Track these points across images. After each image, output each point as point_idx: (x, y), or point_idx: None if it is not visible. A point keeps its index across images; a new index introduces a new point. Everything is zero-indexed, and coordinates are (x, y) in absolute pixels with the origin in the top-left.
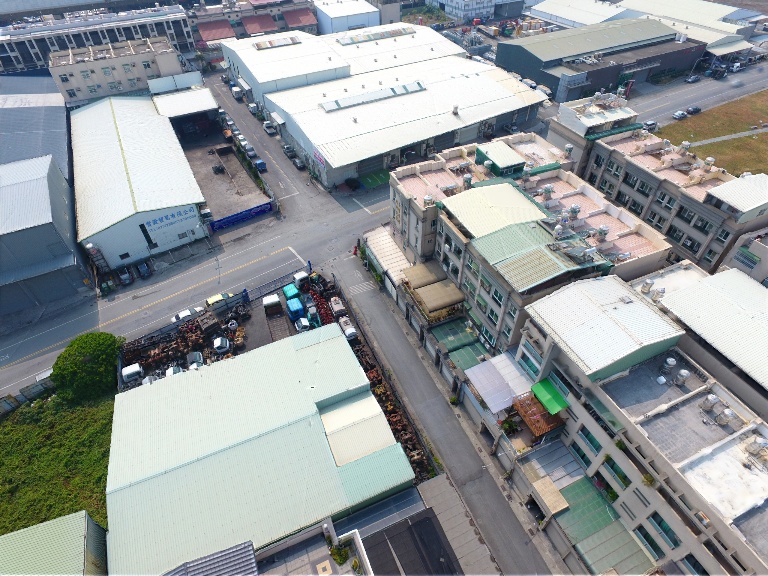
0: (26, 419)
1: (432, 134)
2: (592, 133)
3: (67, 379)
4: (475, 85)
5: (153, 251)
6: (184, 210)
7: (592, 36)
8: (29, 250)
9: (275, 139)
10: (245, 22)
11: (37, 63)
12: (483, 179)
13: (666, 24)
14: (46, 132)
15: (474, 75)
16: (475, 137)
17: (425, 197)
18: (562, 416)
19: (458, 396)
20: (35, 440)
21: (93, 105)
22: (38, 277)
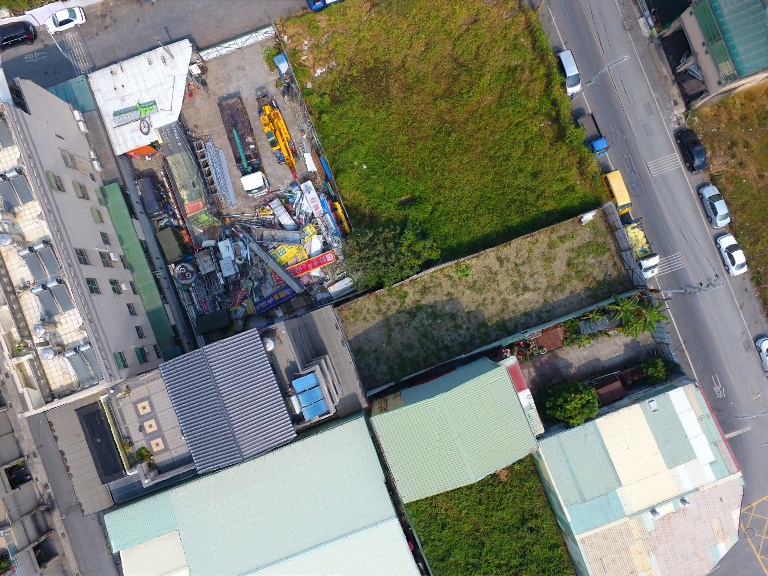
0: None
1: None
2: None
3: None
4: None
5: None
6: None
7: None
8: None
9: None
10: None
11: None
12: None
13: None
14: None
15: None
16: None
17: None
18: None
19: None
20: (528, 575)
21: None
22: None
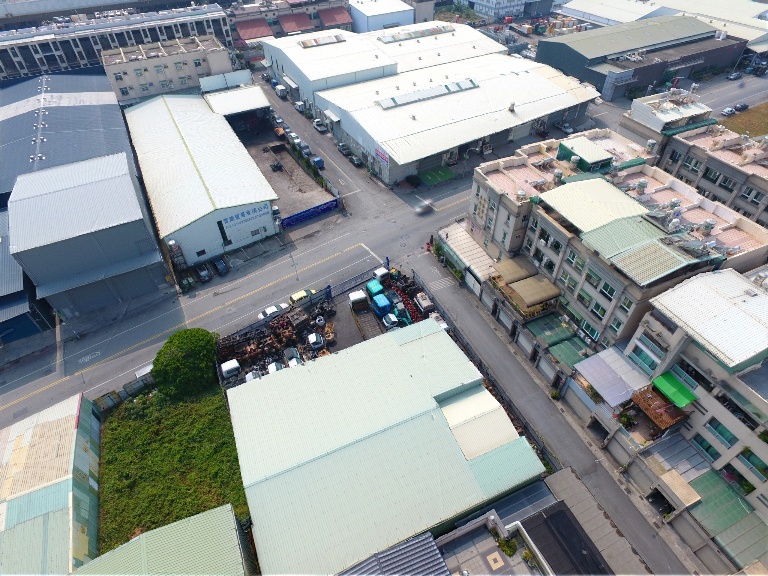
0: (131, 415)
1: (492, 131)
2: (668, 129)
3: (170, 375)
4: (526, 82)
5: (227, 248)
6: (259, 207)
7: (633, 33)
8: (118, 247)
9: (327, 137)
10: (282, 21)
11: (80, 62)
12: (569, 174)
13: (704, 21)
14: (106, 130)
15: (524, 72)
16: (527, 134)
17: (519, 192)
18: (686, 409)
19: (560, 391)
20: (145, 435)
21: (147, 103)
22: (127, 274)
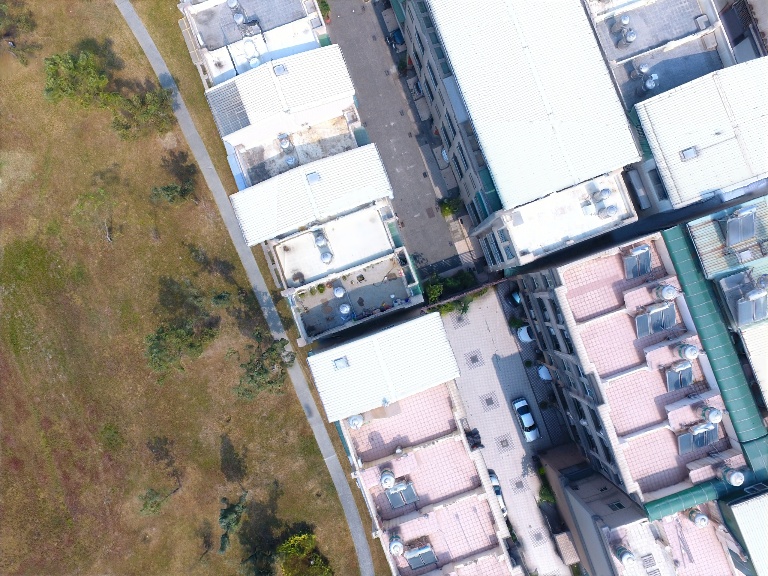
0: None
1: None
2: None
3: None
4: None
5: None
6: None
7: None
8: None
9: None
10: None
11: None
12: None
13: None
14: None
15: None
16: None
17: None
18: None
19: None
20: None
21: None
22: None
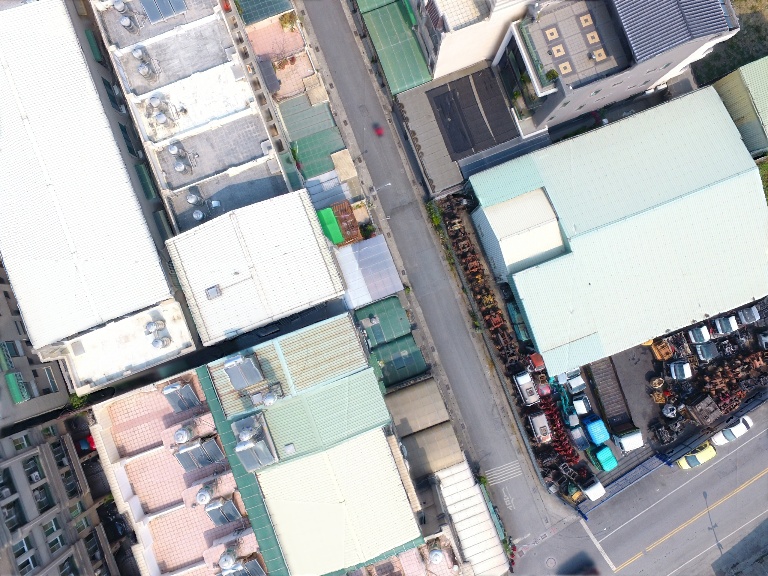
0: None
1: None
2: None
3: None
4: None
5: None
6: None
7: None
8: None
9: None
10: None
11: None
12: None
13: None
14: None
15: None
16: None
17: None
18: None
19: None
20: None
21: None
22: None
